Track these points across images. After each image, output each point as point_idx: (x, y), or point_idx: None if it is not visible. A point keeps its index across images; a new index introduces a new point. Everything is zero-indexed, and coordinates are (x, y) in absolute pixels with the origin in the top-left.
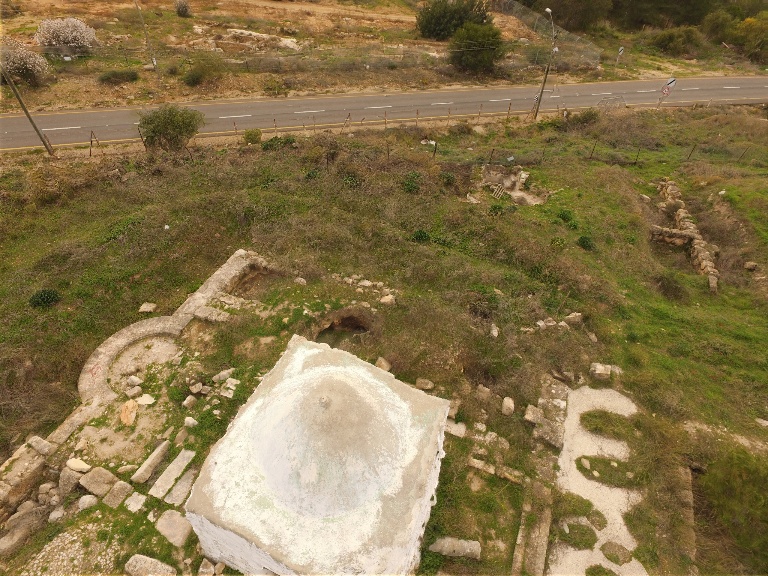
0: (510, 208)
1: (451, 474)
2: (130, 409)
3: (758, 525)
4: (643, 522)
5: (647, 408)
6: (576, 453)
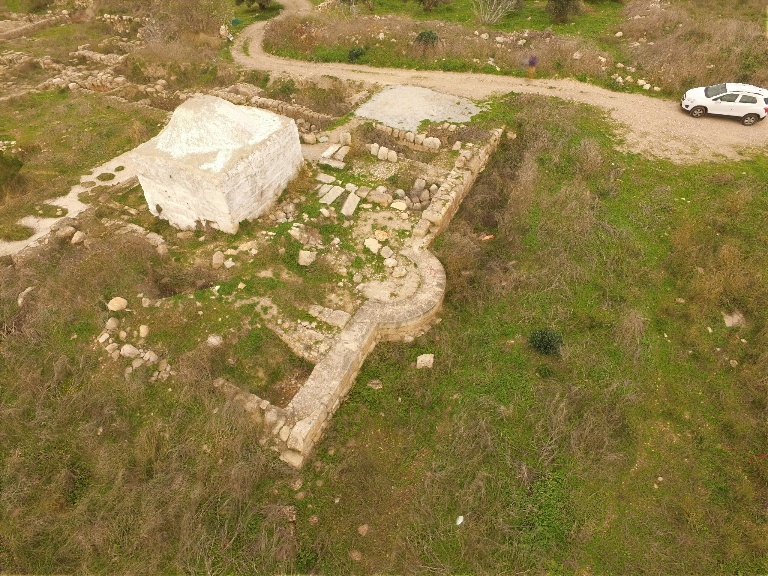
0: None
1: None
2: (380, 234)
3: (5, 159)
4: None
5: None
6: None
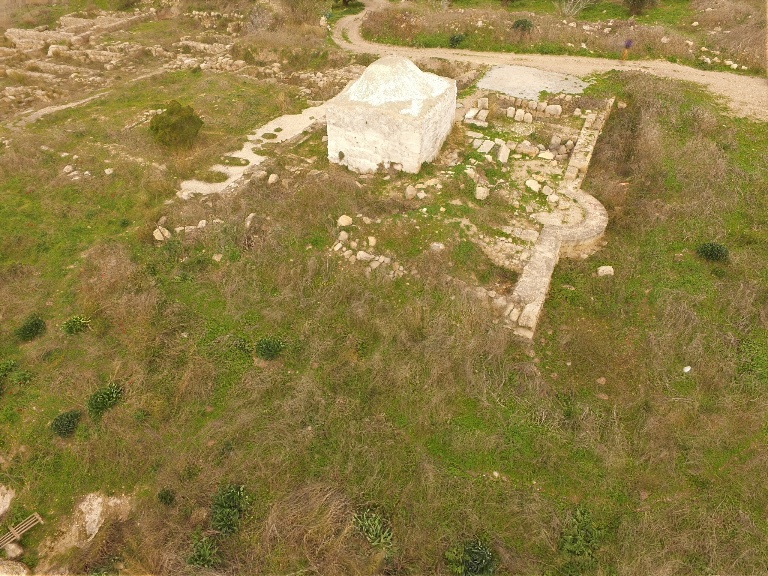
0: (70, 413)
1: (326, 159)
2: None
3: None
4: (234, 146)
5: (176, 179)
6: (245, 167)
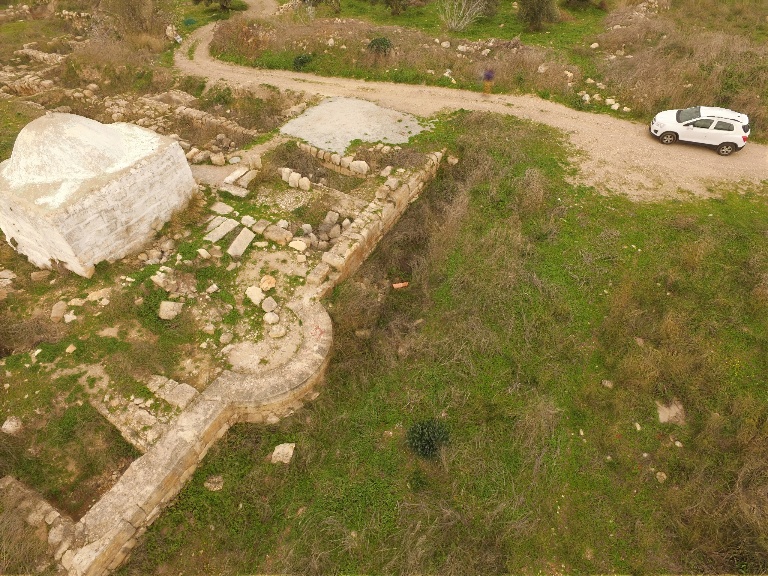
0: None
1: None
2: (266, 282)
3: None
4: None
5: None
6: None
